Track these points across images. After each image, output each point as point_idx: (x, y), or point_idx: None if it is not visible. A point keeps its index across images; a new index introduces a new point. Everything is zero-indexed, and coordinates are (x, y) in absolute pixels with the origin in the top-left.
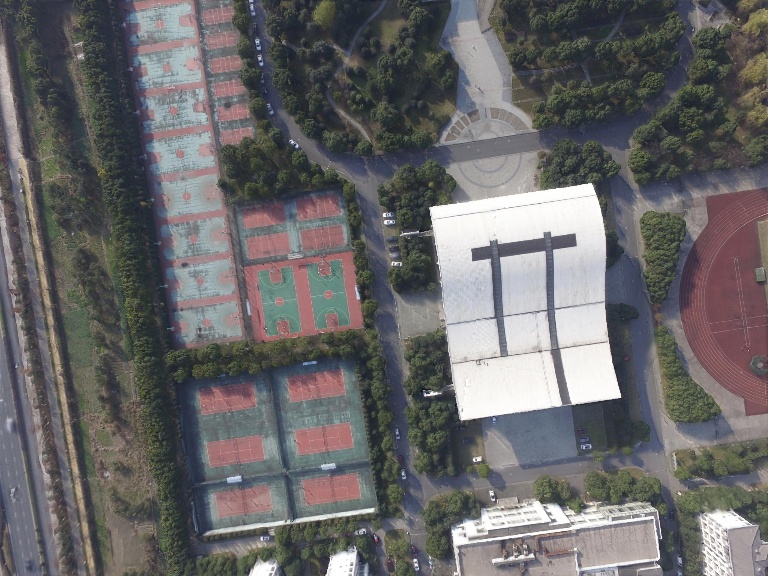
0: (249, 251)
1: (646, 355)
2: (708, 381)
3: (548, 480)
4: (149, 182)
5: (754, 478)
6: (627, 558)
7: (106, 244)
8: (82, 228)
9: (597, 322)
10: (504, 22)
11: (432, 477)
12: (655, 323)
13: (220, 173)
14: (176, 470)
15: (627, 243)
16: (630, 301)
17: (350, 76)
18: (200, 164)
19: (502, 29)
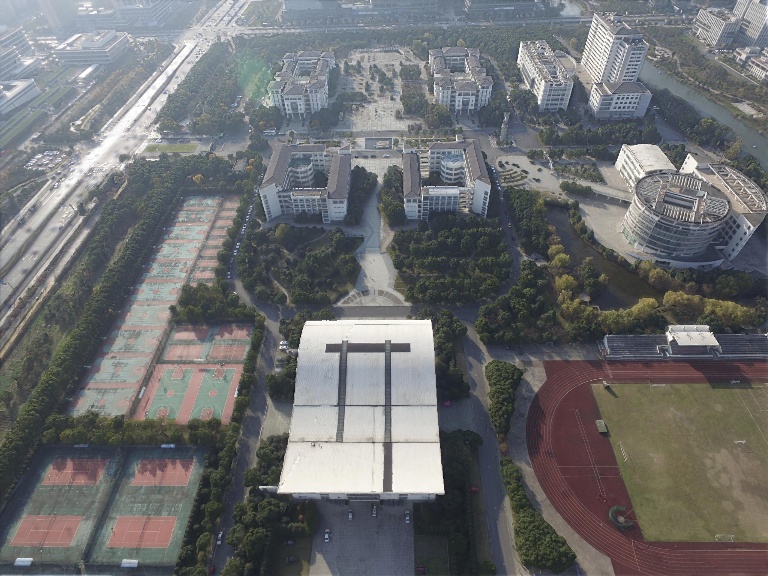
0: (167, 354)
1: (496, 490)
2: (565, 529)
3: None
4: (125, 304)
5: None
6: None
7: (67, 335)
8: (58, 323)
9: (429, 423)
10: (394, 248)
11: None
12: None
13: (176, 304)
14: None
15: (477, 387)
16: None
17: (288, 264)
18: (166, 298)
19: (394, 253)
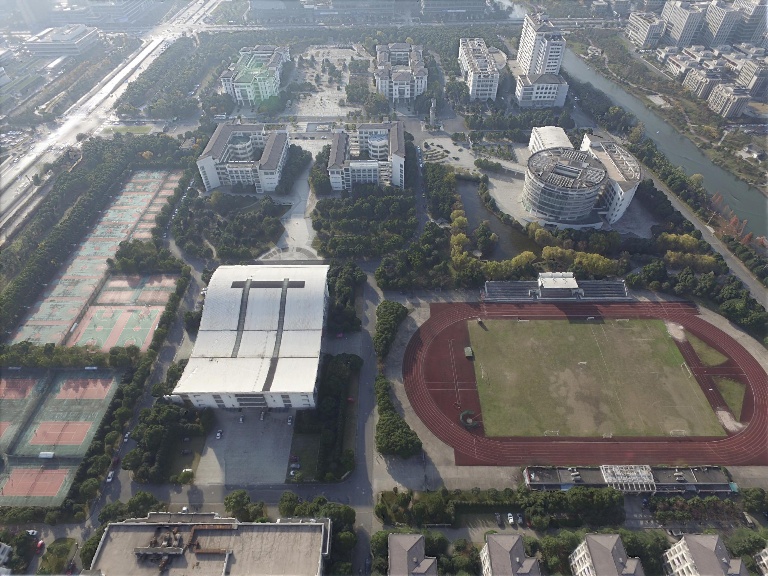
0: (101, 298)
1: (369, 401)
2: (421, 428)
3: (241, 492)
4: (67, 258)
5: (464, 536)
6: (283, 572)
7: (12, 282)
8: (5, 273)
9: (313, 343)
10: (315, 213)
11: (136, 484)
12: None
13: (114, 259)
14: None
15: (369, 323)
16: (364, 360)
17: (219, 226)
18: (105, 254)
19: (316, 218)
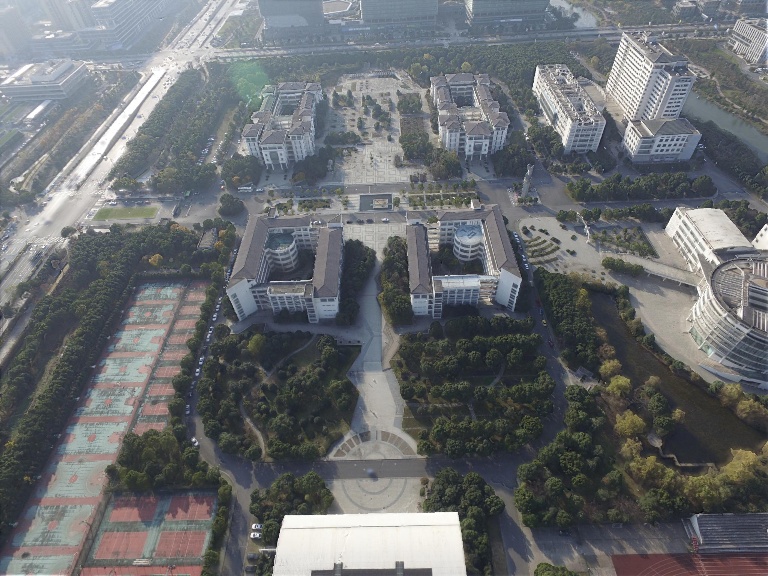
0: (99, 549)
1: None
2: None
3: None
4: (49, 460)
5: None
6: None
7: None
8: None
9: None
10: (400, 364)
11: None
12: None
13: (116, 460)
14: None
15: None
16: None
17: (265, 391)
18: (104, 449)
19: (400, 370)
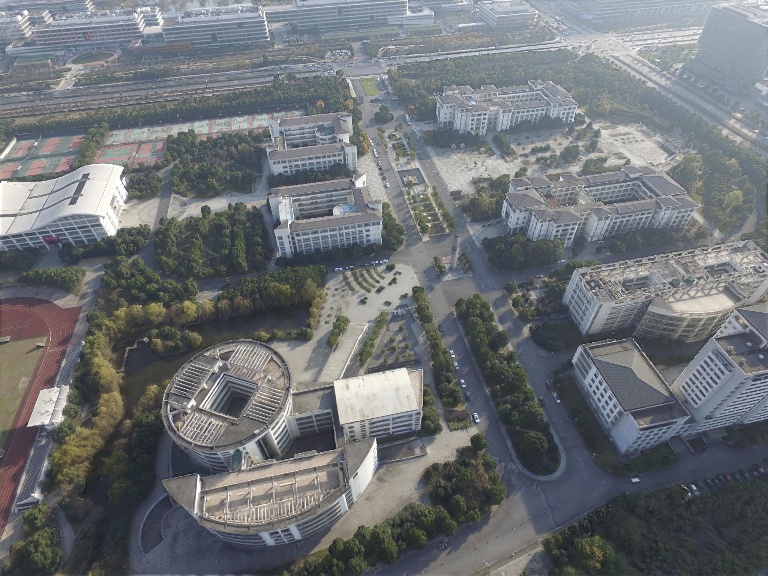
0: (146, 144)
1: None
2: None
3: None
4: None
5: None
6: None
7: None
8: None
9: None
10: (229, 207)
11: None
12: (8, 286)
13: None
14: (51, 127)
15: None
16: None
17: None
18: None
19: None
